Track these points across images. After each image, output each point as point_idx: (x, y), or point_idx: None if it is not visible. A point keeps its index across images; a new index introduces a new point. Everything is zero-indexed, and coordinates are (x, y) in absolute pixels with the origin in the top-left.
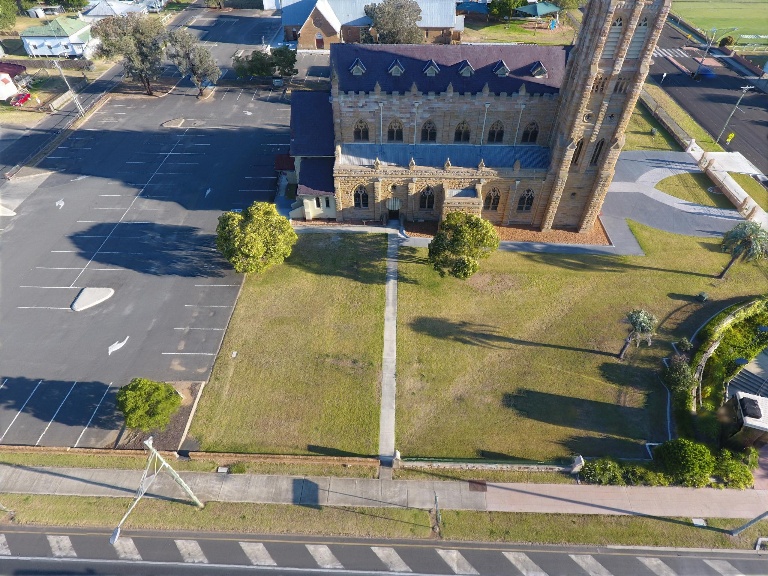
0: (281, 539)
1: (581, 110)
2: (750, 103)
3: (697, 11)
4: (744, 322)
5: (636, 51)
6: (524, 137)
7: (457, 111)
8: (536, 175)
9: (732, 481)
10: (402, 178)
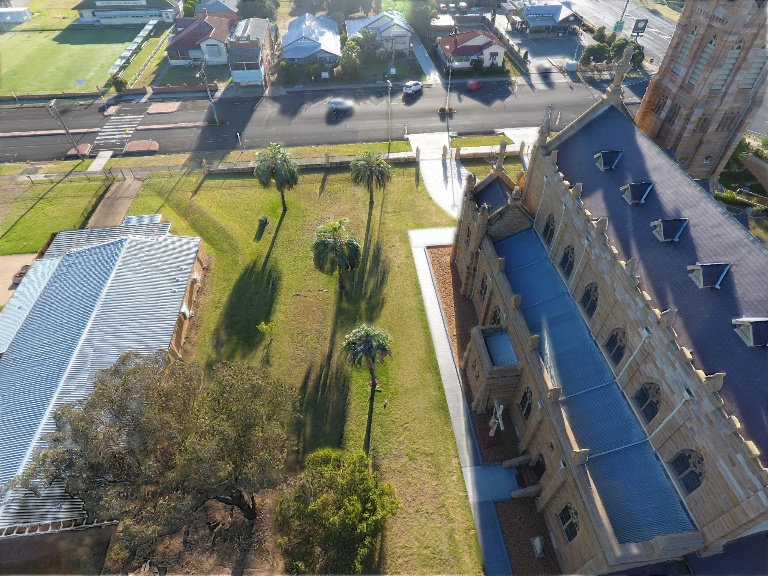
0: None
1: None
2: (292, 108)
3: None
4: None
5: None
6: None
7: None
8: None
9: None
10: None
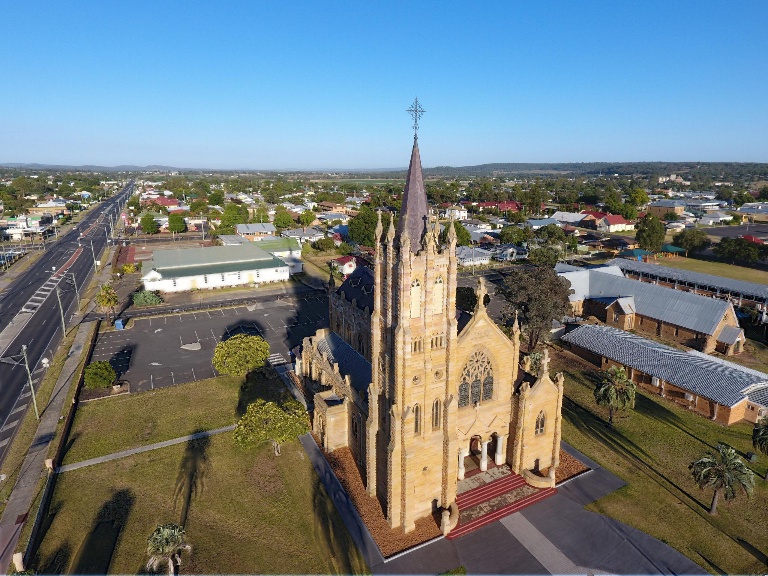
0: (7, 449)
1: None
2: None
3: None
4: None
5: None
6: None
7: None
8: None
9: None
10: None
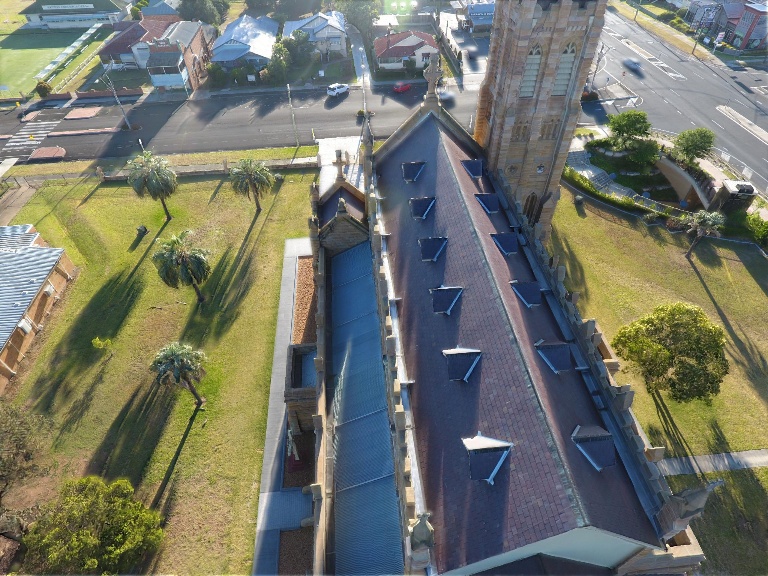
0: None
1: None
2: (211, 112)
3: None
4: None
5: None
6: None
7: None
8: None
9: (762, 222)
10: None
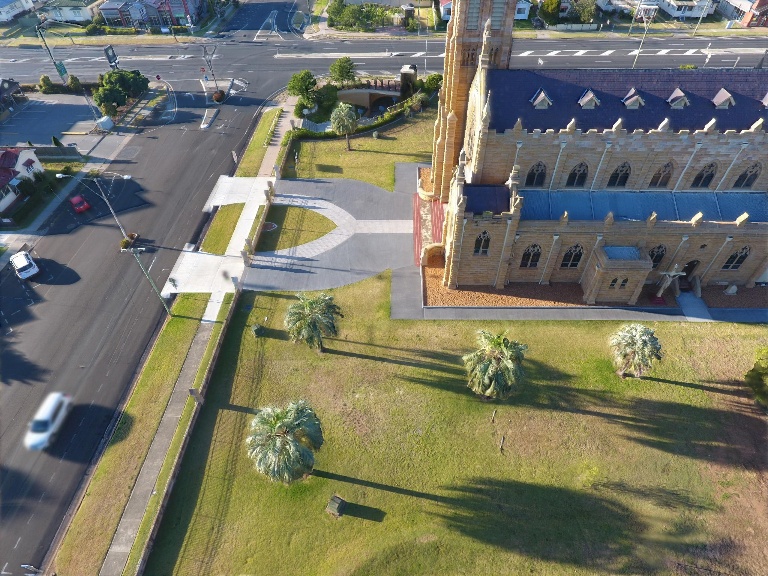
0: None
1: None
2: None
3: None
4: None
5: None
6: None
7: None
8: None
9: None
10: None
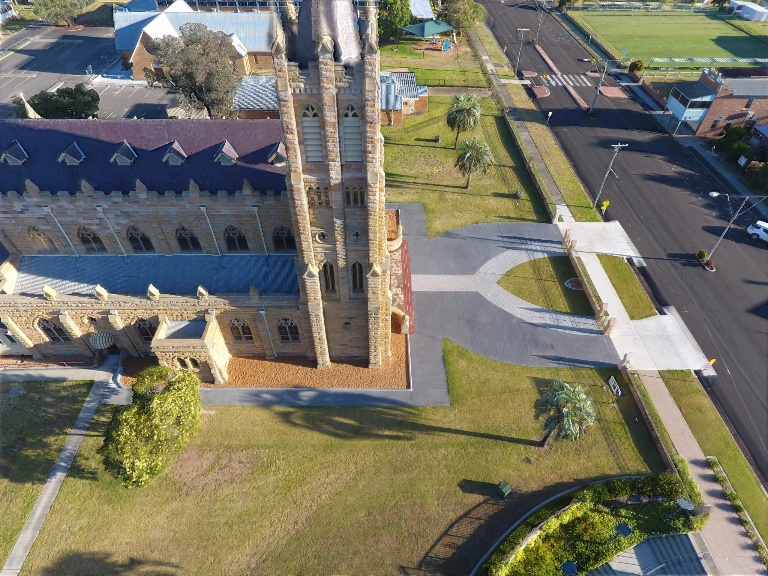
0: None
1: (303, 230)
2: (646, 148)
3: (616, 27)
4: (559, 530)
5: (357, 151)
6: (278, 244)
7: (165, 215)
8: (285, 303)
9: None
10: (96, 310)
